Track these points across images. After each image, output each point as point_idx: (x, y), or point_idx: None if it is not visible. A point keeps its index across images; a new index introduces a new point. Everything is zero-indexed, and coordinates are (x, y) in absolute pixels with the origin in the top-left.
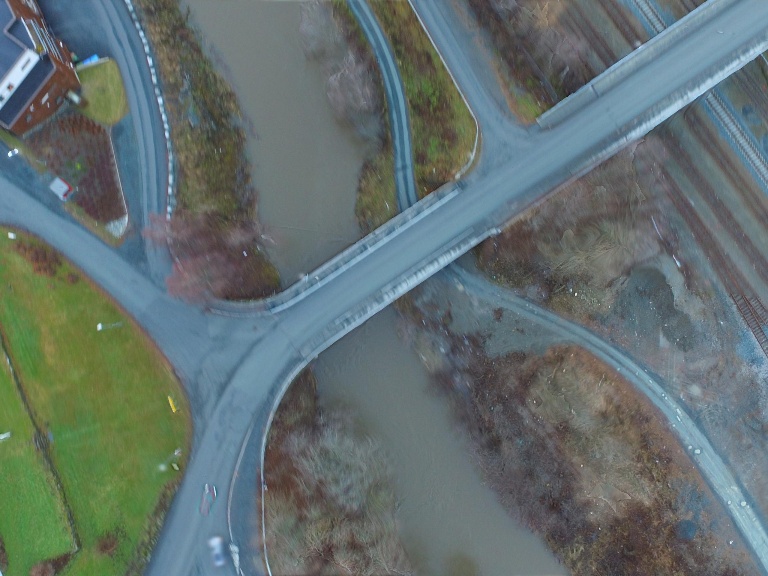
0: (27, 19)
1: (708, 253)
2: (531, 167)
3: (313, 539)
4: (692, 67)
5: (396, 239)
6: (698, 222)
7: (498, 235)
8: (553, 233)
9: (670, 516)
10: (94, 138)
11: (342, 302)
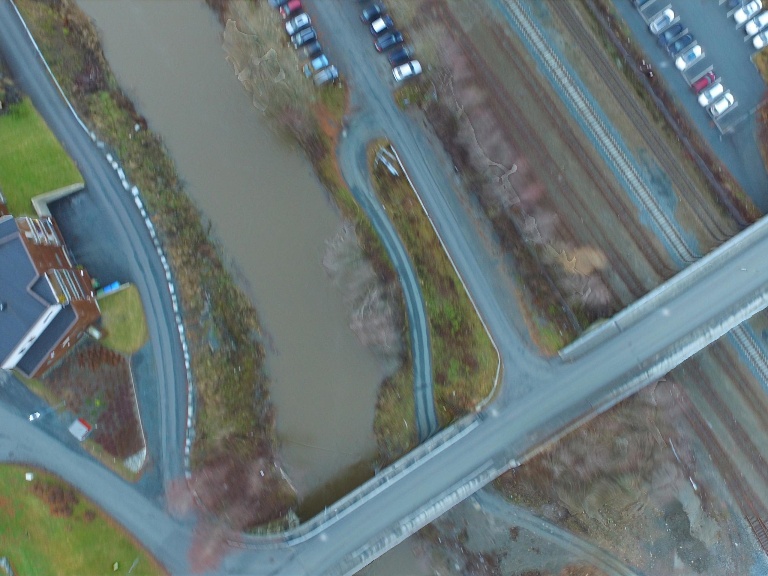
0: (50, 266)
1: (724, 475)
2: (552, 399)
3: None
4: (715, 304)
5: (415, 471)
6: (715, 444)
7: (517, 466)
8: (573, 478)
9: None
10: (114, 369)
11: (360, 534)
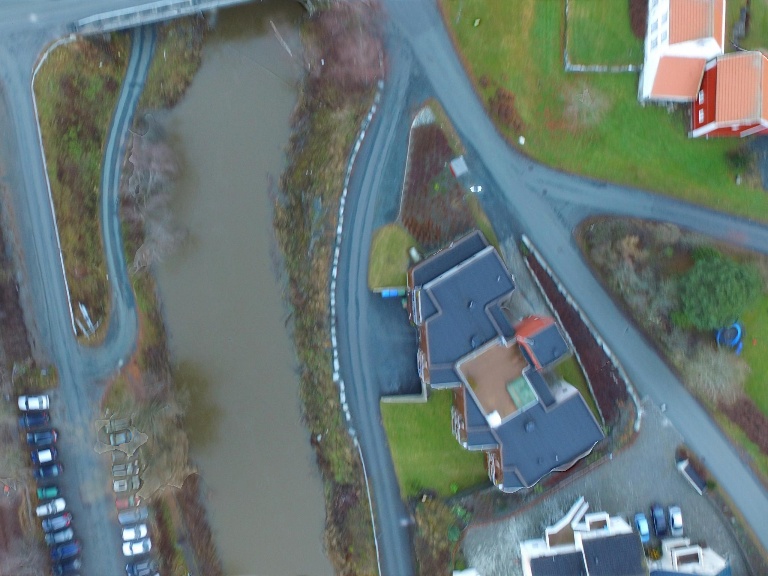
0: None
1: None
2: None
3: None
4: None
5: None
6: None
7: None
8: None
9: None
10: (415, 214)
11: None
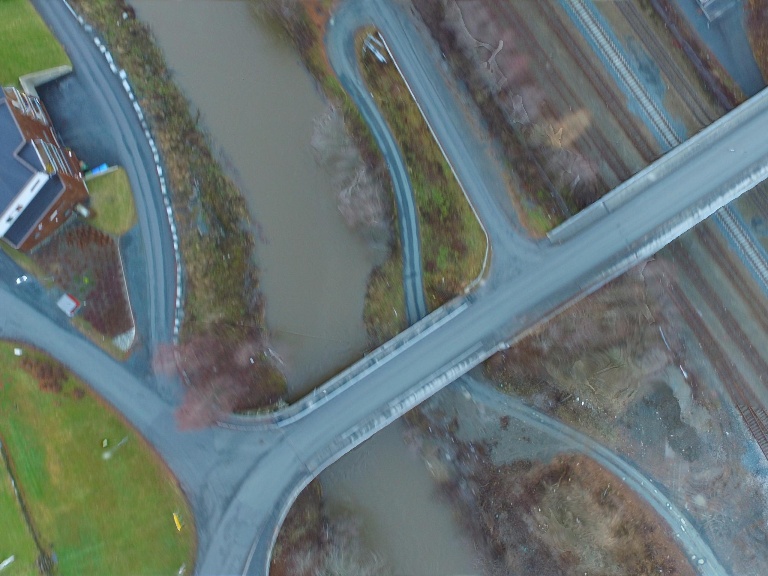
0: (37, 137)
1: (715, 364)
2: (541, 281)
3: None
4: (703, 185)
5: (404, 353)
6: (706, 333)
7: (506, 349)
8: (562, 354)
9: None
10: (102, 249)
11: (349, 416)
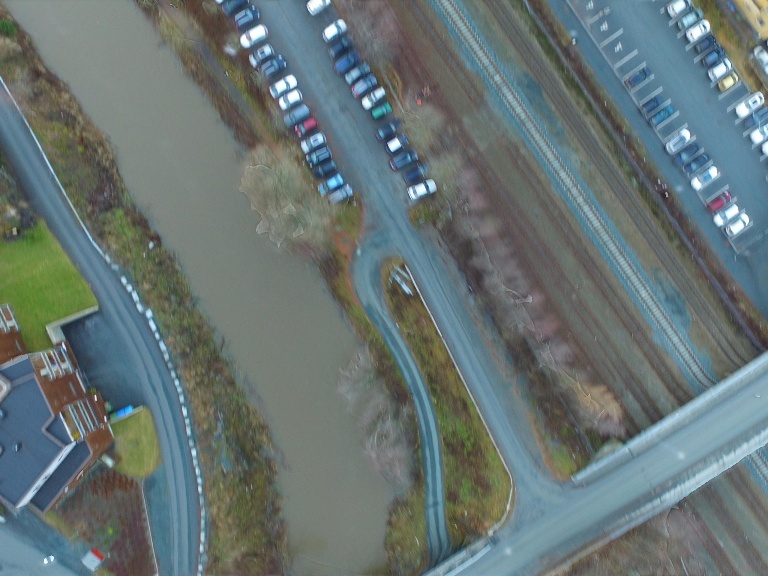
0: (64, 401)
1: None
2: (564, 523)
3: None
4: (729, 431)
5: None
6: (727, 563)
7: None
8: None
9: None
10: (126, 495)
11: None
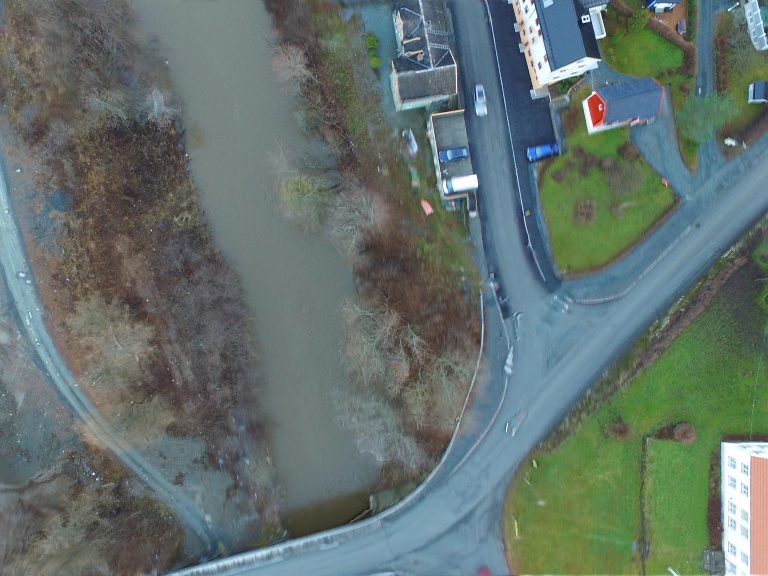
0: None
1: None
2: None
3: (423, 394)
4: None
5: None
6: None
7: (150, 573)
8: (90, 574)
9: (74, 223)
10: None
11: (325, 560)
